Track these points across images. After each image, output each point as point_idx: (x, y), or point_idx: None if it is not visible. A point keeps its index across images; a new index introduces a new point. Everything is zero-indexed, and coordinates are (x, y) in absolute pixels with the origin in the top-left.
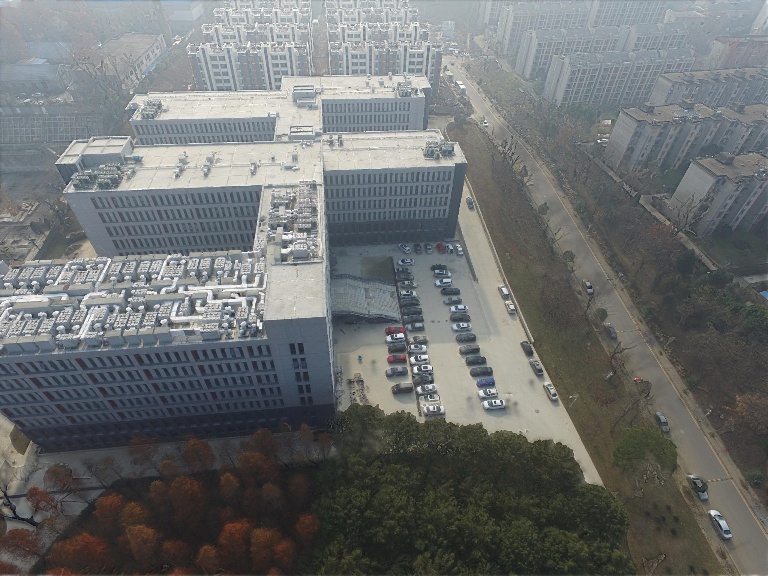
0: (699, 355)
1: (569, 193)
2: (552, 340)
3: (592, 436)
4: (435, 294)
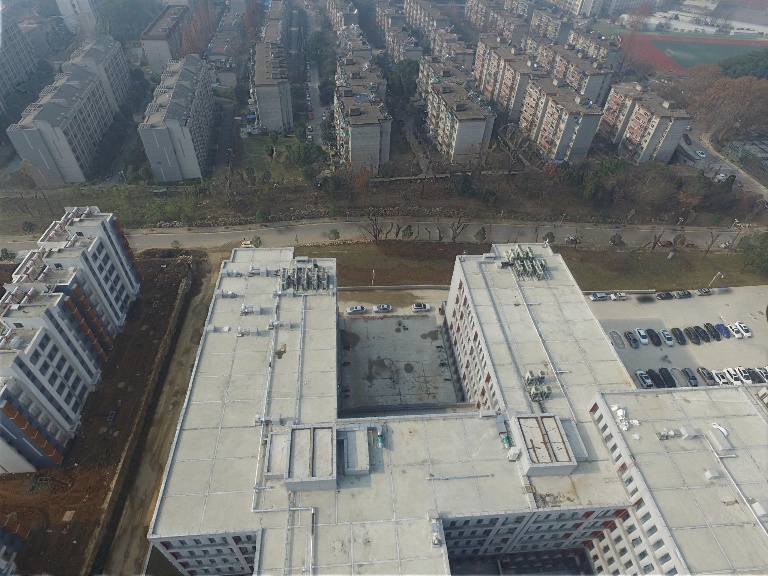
0: (657, 202)
1: (436, 213)
2: (647, 278)
3: (728, 280)
4: (626, 355)
